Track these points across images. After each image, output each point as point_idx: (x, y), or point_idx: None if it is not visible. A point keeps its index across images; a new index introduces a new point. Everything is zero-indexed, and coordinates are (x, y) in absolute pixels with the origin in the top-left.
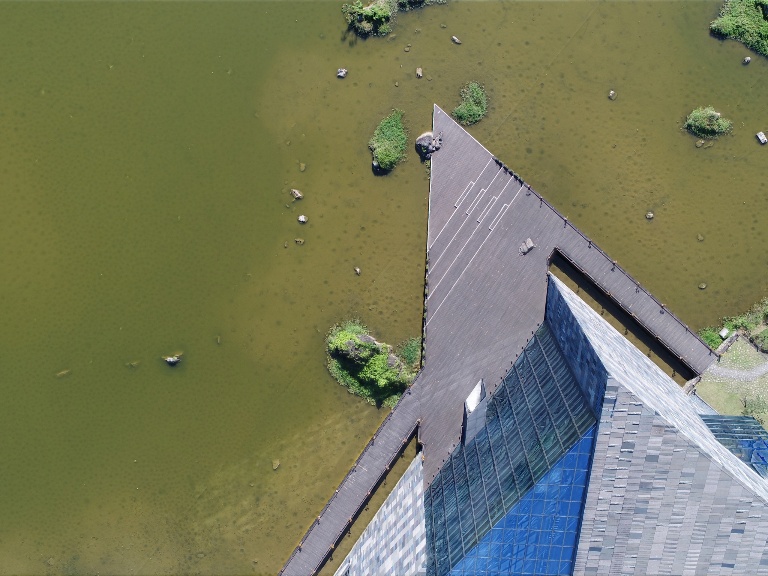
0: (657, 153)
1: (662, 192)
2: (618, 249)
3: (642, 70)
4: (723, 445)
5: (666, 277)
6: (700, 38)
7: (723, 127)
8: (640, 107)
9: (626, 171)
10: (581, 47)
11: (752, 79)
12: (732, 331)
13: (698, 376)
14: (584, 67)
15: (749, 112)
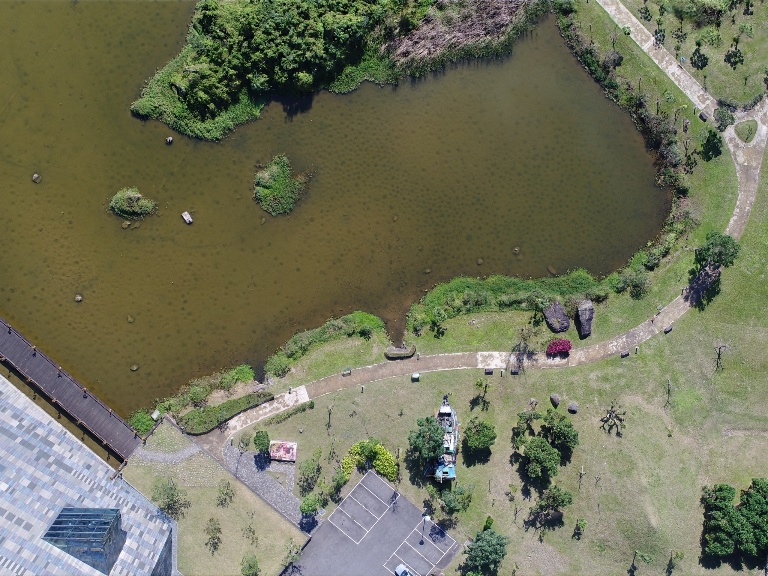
0: (84, 235)
1: (90, 274)
2: (48, 333)
3: (66, 152)
4: (55, 544)
5: (98, 360)
6: (123, 119)
7: (147, 208)
8: (65, 190)
9: (53, 254)
10: (4, 131)
11: (177, 159)
12: (163, 413)
13: (124, 460)
14: (8, 151)
15: (175, 192)
